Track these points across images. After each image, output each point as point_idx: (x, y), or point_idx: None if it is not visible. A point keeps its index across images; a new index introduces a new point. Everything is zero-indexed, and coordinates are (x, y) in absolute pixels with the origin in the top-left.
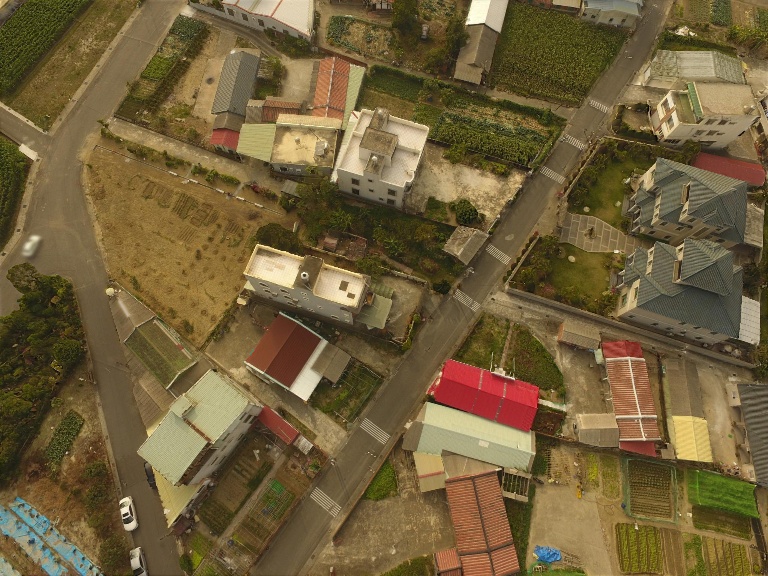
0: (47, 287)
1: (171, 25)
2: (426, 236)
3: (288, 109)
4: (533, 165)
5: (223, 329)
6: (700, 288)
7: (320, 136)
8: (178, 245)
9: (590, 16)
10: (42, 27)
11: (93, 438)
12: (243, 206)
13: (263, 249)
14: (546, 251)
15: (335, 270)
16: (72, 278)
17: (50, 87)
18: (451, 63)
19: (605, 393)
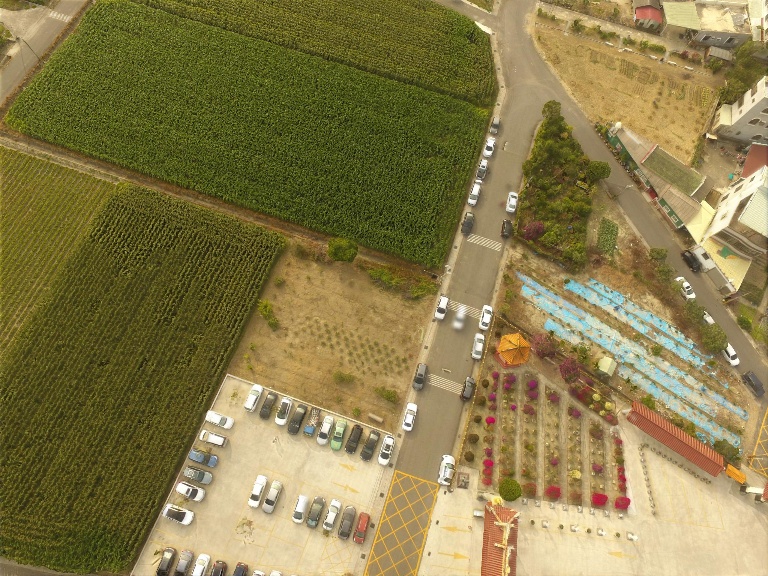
0: (556, 125)
1: None
2: None
3: None
4: None
5: (700, 159)
6: None
7: (732, 11)
8: (636, 98)
9: None
10: None
11: (630, 237)
12: (675, 69)
13: None
14: None
15: None
16: None
17: None
18: None
19: None
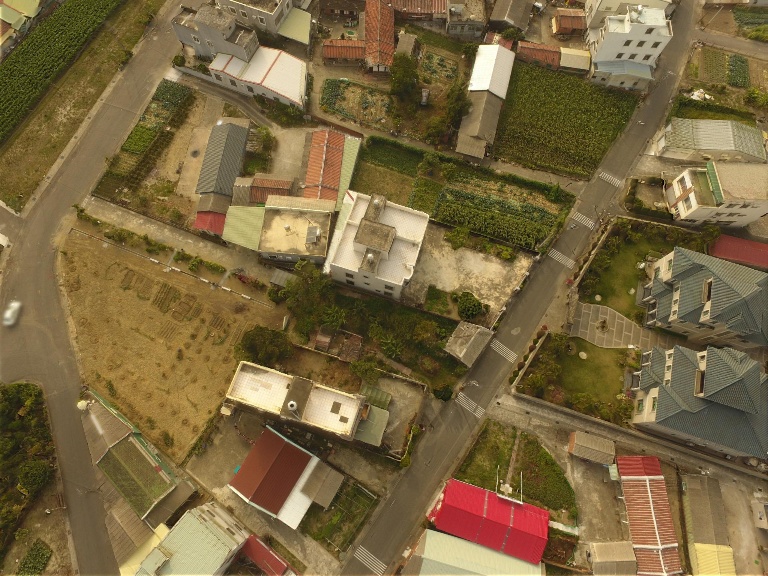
0: (14, 397)
1: (154, 90)
2: (426, 336)
3: (278, 189)
4: (541, 249)
5: (206, 442)
6: (725, 404)
7: (312, 220)
8: (158, 343)
9: (600, 78)
10: (16, 95)
11: (61, 572)
12: (229, 297)
13: (248, 365)
14: (555, 350)
15: (326, 389)
16: (42, 383)
17: (24, 162)
18: (453, 133)
19: (620, 513)
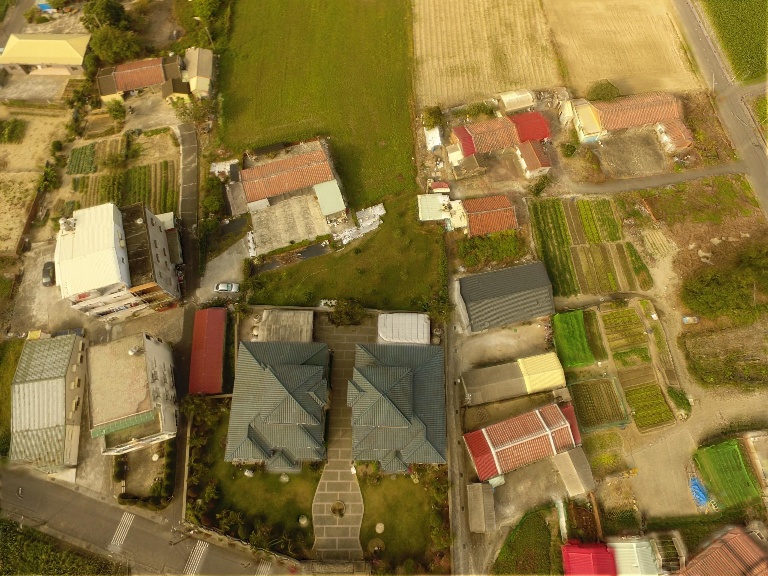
0: None
1: None
2: None
3: None
4: None
5: None
6: None
7: None
8: None
9: None
10: None
11: None
12: None
13: None
14: None
15: None
16: None
17: None
18: None
19: None
